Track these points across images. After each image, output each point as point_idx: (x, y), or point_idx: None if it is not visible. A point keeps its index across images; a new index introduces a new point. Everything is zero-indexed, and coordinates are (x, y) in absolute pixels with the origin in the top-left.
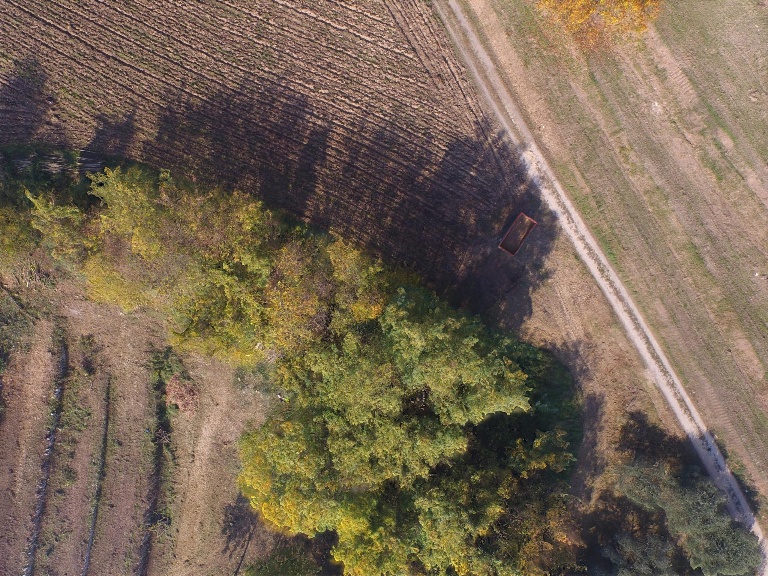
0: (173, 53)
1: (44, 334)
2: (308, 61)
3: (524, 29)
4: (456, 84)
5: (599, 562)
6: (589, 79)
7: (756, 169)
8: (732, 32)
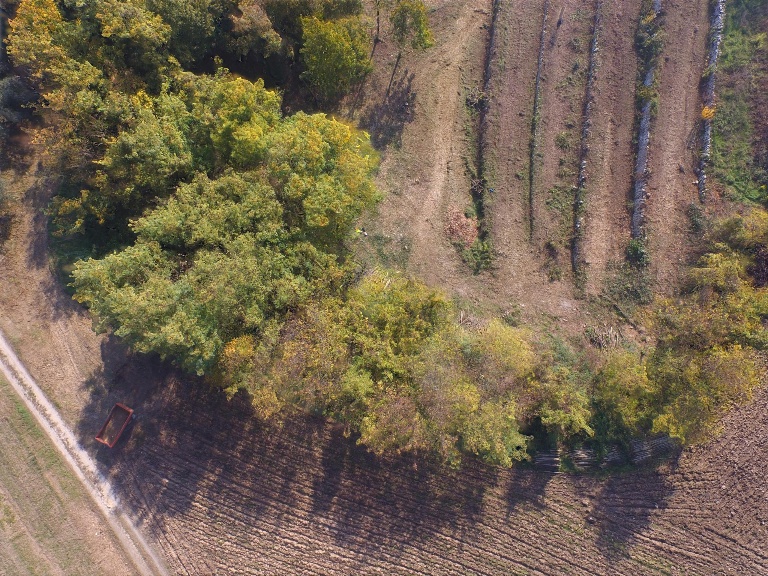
0: None
1: (594, 281)
2: None
3: None
4: (188, 569)
5: None
6: None
7: None
8: None
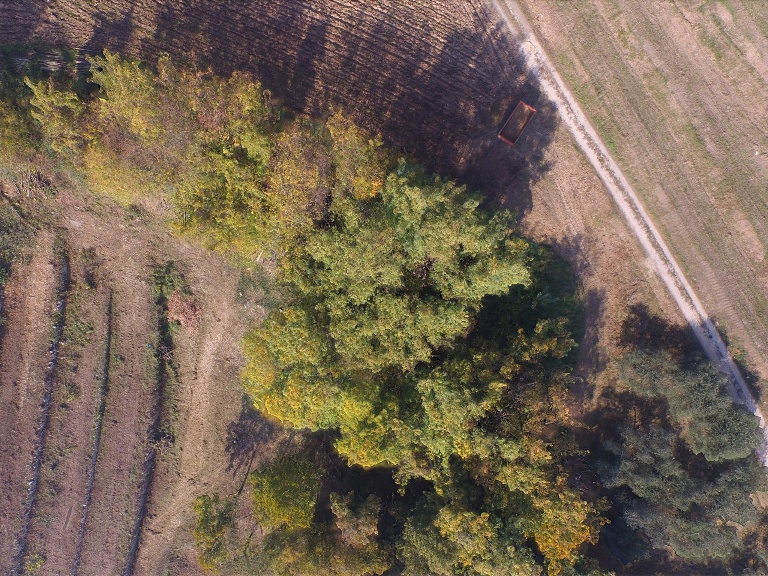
0: None
1: (45, 245)
2: None
3: None
4: None
5: (602, 457)
6: None
7: (755, 43)
8: None
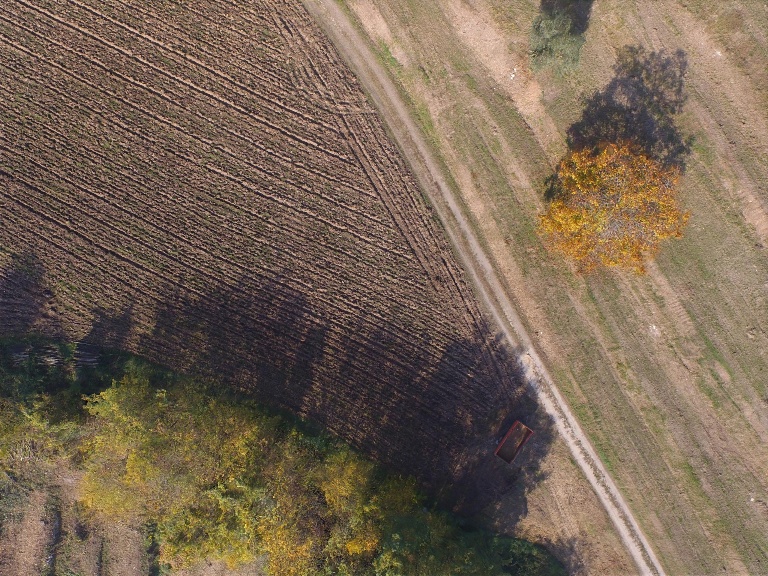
0: (172, 249)
1: (37, 504)
2: (307, 260)
3: (523, 239)
4: (455, 286)
5: None
6: (587, 295)
7: (753, 404)
8: (730, 269)
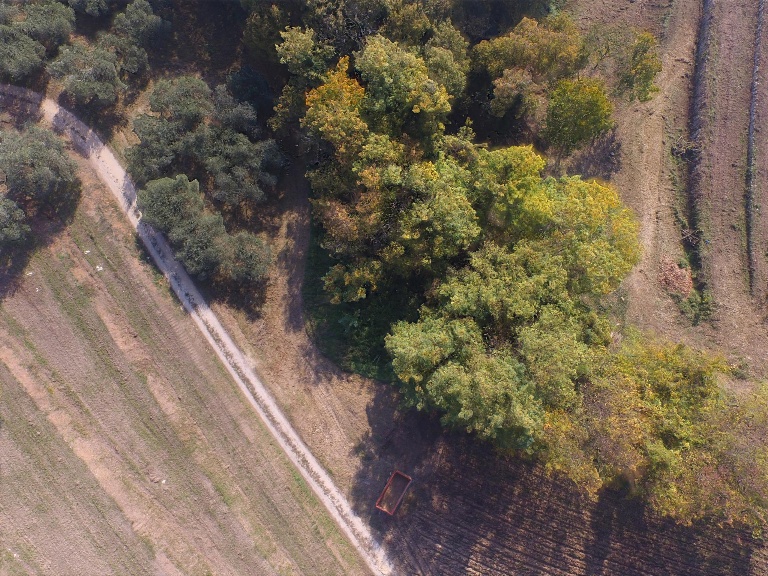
0: None
1: None
2: None
3: None
4: None
5: (277, 169)
6: None
7: None
8: None
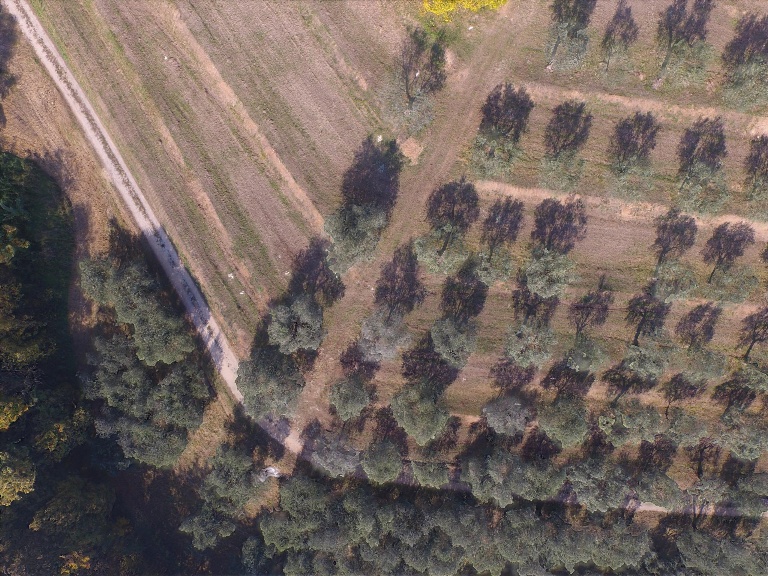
0: None
1: None
2: None
3: None
4: None
5: None
6: None
7: None
8: None
